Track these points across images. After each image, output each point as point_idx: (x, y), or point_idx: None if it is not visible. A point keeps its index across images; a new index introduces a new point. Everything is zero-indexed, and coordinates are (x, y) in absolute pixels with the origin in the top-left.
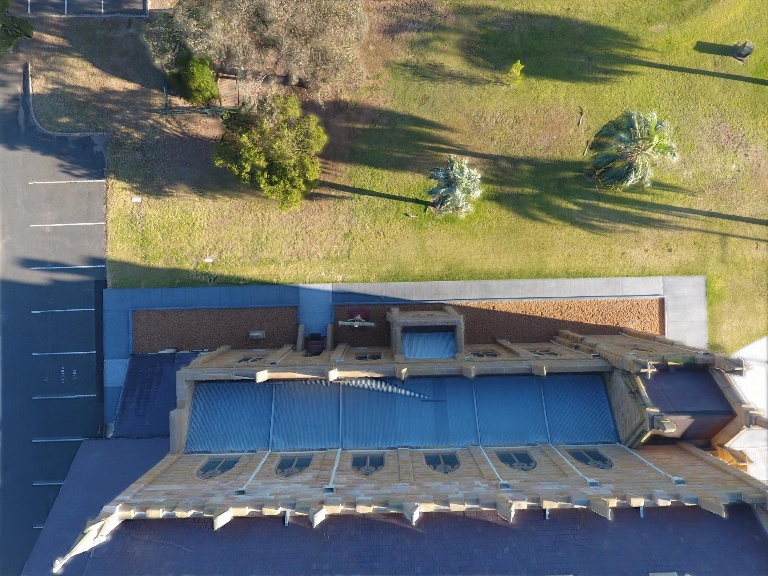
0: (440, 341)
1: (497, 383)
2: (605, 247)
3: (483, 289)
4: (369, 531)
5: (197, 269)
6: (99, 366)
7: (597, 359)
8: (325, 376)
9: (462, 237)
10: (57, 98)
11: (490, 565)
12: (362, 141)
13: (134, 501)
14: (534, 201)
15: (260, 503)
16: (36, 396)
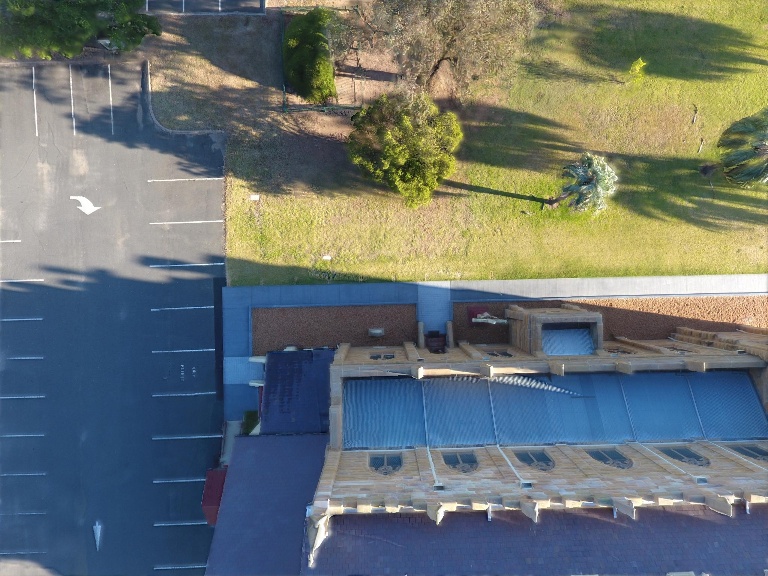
0: (576, 338)
1: (644, 379)
2: (720, 244)
3: (600, 286)
4: (574, 526)
5: (316, 267)
6: (219, 364)
7: (745, 355)
8: (483, 372)
9: (579, 234)
10: (176, 96)
11: (704, 559)
12: (478, 139)
13: (337, 496)
14: (649, 198)
15: (466, 498)
16: (156, 394)
